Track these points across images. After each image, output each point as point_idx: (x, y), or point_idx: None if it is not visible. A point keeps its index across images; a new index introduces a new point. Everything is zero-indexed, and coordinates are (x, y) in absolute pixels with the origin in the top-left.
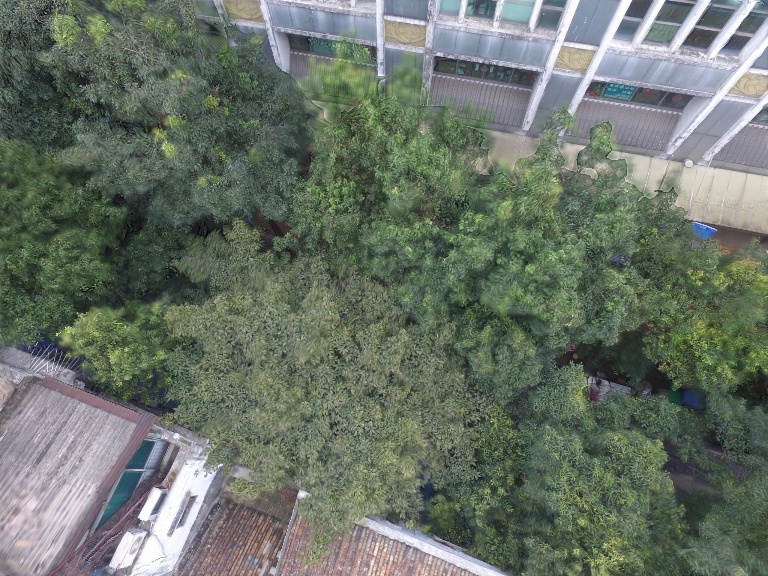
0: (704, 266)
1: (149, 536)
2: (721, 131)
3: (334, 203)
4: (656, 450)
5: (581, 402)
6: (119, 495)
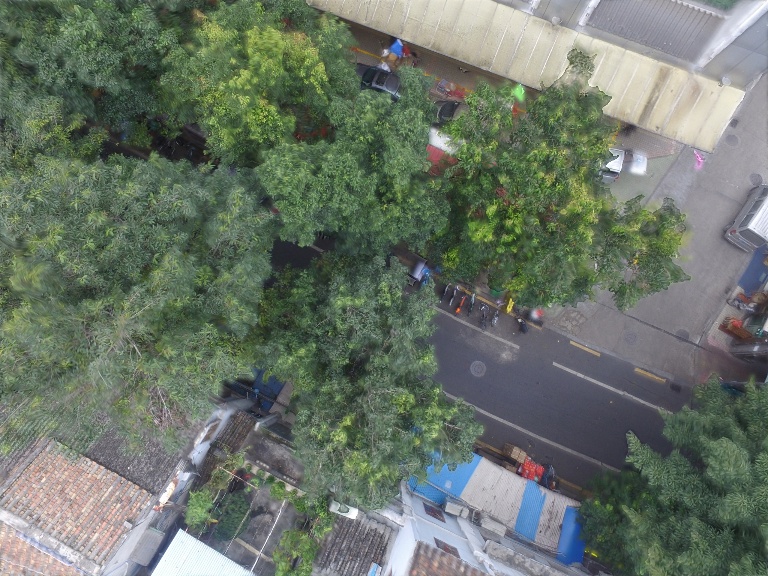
0: (220, 20)
1: None
2: None
3: None
4: (59, 167)
5: (33, 125)
6: None
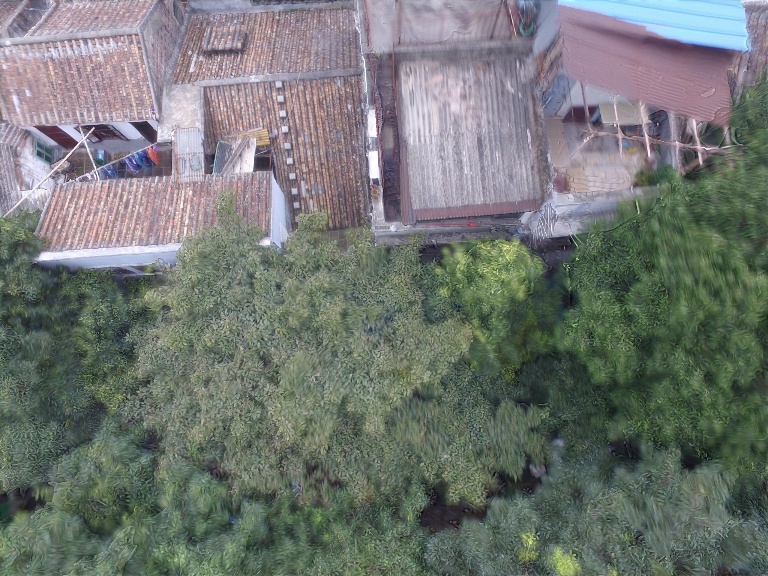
0: None
1: (367, 147)
2: None
3: None
4: None
5: None
6: None
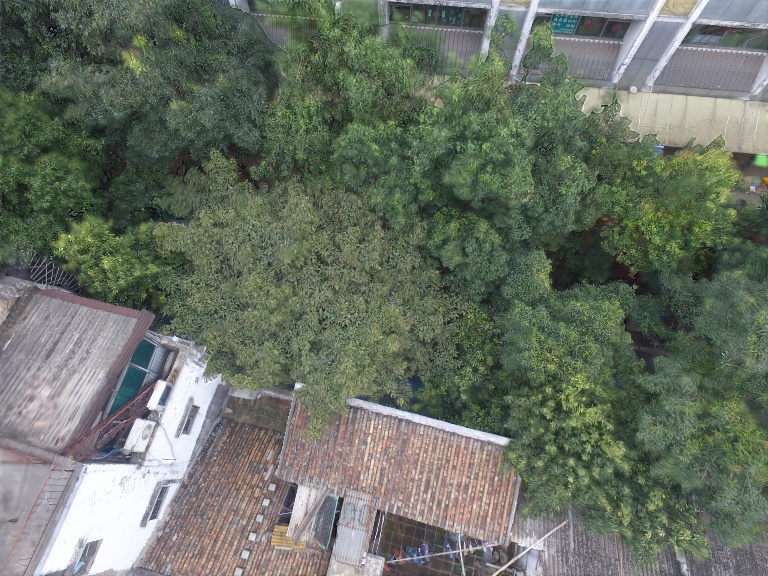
0: (646, 156)
1: (158, 426)
2: (658, 54)
3: (304, 124)
4: (614, 308)
5: None
6: (127, 388)
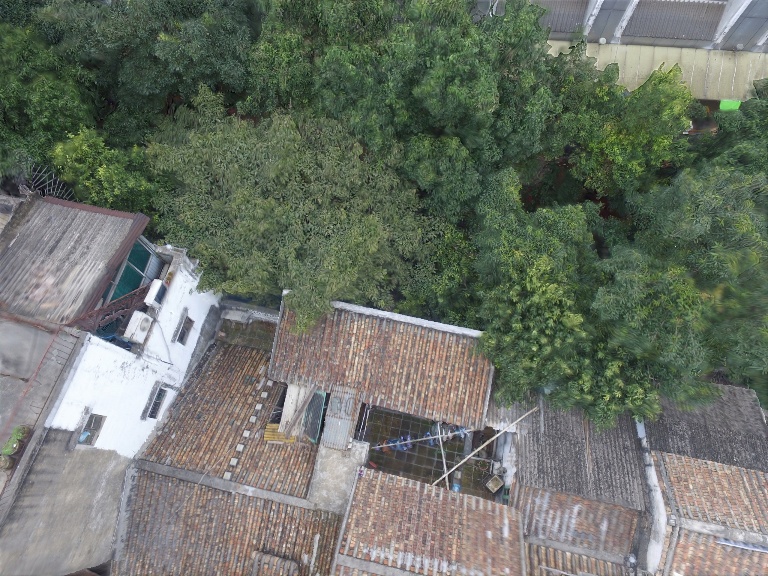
0: (608, 82)
1: (155, 322)
2: (625, 4)
3: (286, 56)
4: (576, 210)
5: (514, 191)
6: (125, 285)
